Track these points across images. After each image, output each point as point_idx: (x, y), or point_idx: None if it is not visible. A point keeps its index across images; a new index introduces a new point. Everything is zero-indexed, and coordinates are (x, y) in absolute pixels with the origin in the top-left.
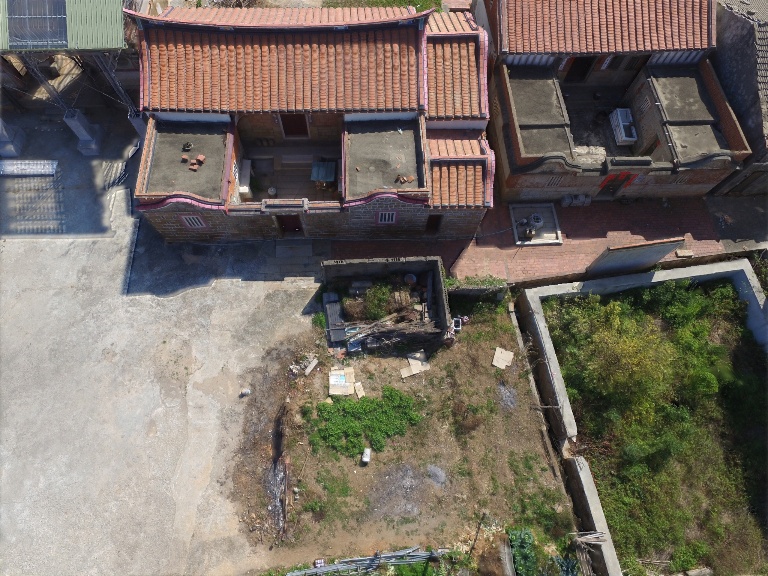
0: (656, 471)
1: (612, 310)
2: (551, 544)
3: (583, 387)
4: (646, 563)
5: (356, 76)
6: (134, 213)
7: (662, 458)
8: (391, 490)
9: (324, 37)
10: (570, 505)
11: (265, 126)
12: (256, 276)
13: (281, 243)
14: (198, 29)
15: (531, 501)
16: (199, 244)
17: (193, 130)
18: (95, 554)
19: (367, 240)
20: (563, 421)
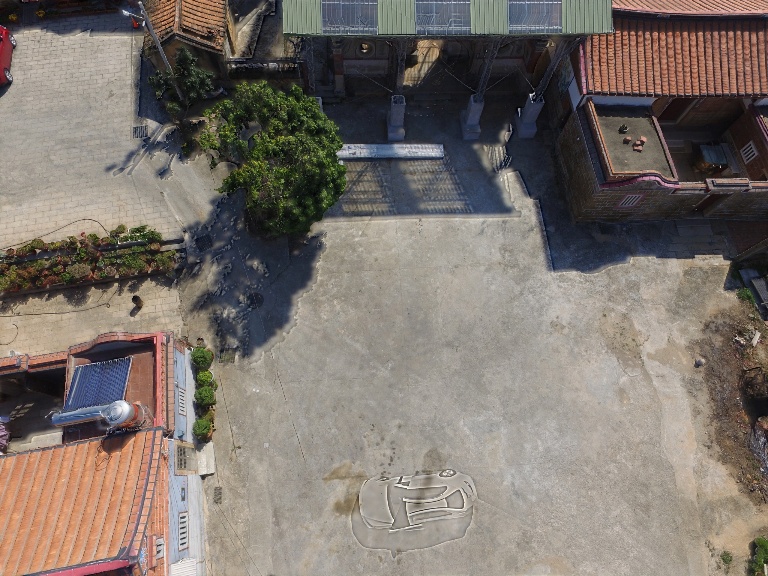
0: None
1: None
2: None
3: None
4: None
5: None
6: (531, 194)
7: None
8: None
9: (747, 24)
10: None
11: None
12: (668, 254)
13: (682, 223)
14: (638, 16)
15: None
16: (607, 223)
17: (620, 113)
18: (613, 512)
19: (758, 220)
20: None
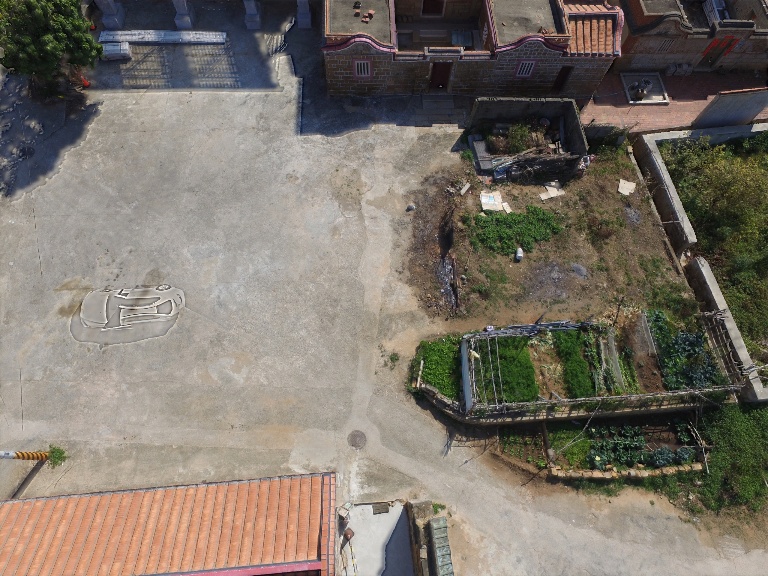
0: (762, 277)
1: (717, 154)
2: (680, 322)
3: (695, 214)
4: (758, 344)
5: None
6: (297, 74)
7: (766, 268)
8: (542, 280)
9: None
10: (693, 295)
11: (409, 1)
12: (408, 123)
13: (427, 98)
14: None
15: (661, 290)
16: (357, 97)
17: None
18: (302, 320)
19: None
20: (684, 231)
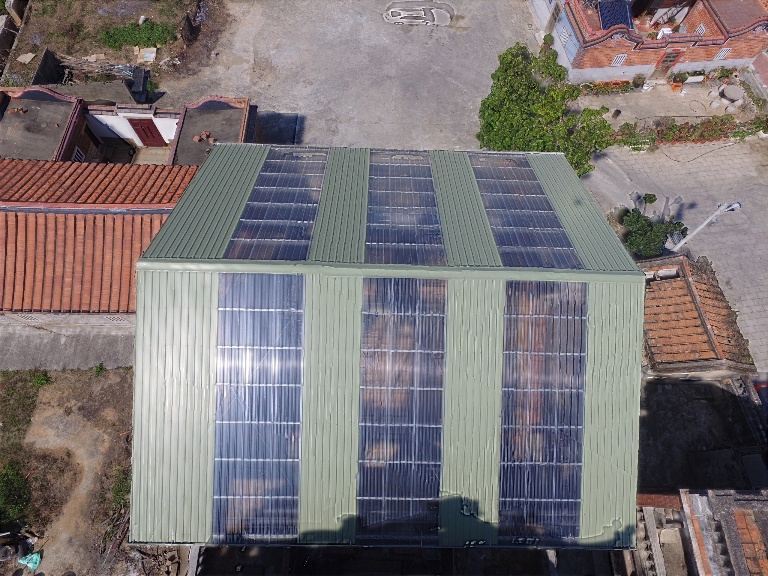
0: None
1: None
2: None
3: None
4: None
5: (6, 178)
6: None
7: None
8: (134, 8)
9: None
10: None
11: None
12: None
13: None
14: None
15: None
16: None
17: None
18: (306, 4)
19: None
20: (6, 21)
